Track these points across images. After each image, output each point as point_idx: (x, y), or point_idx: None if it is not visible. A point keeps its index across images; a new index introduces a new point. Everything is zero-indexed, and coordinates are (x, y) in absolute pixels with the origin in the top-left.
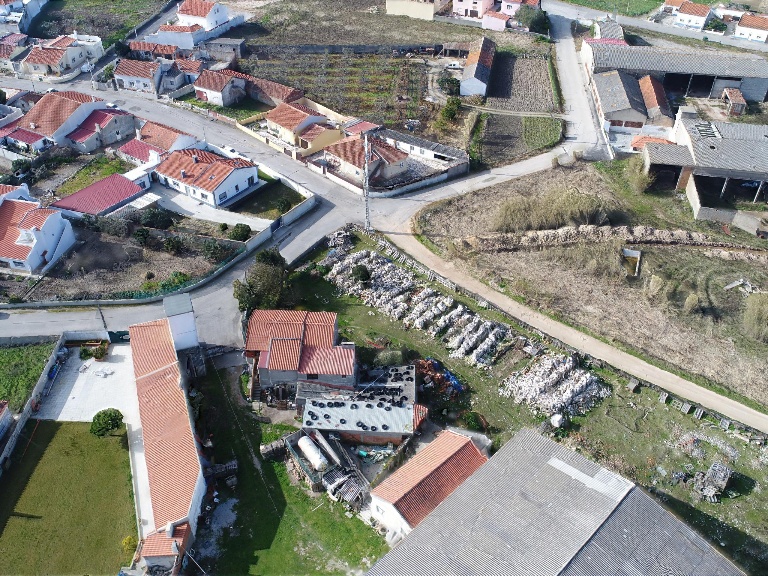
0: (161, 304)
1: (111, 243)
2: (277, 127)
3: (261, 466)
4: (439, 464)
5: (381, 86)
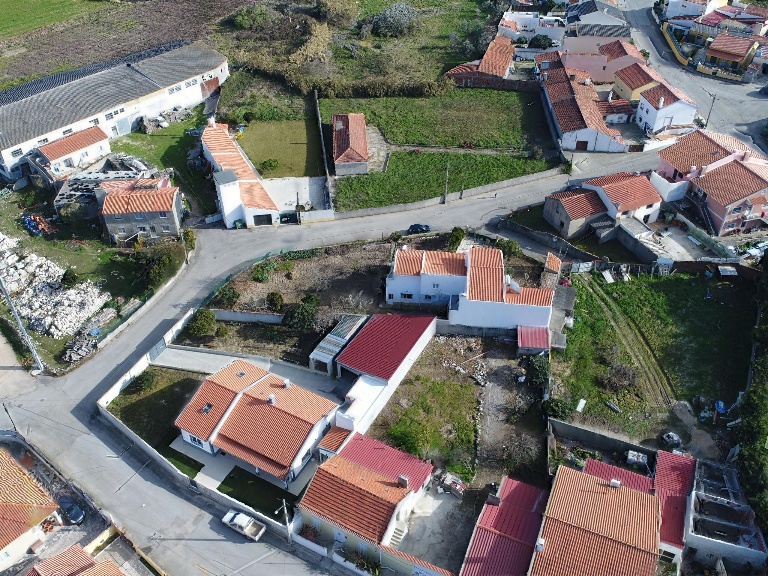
0: None
1: None
2: None
3: (175, 171)
4: (64, 139)
5: None
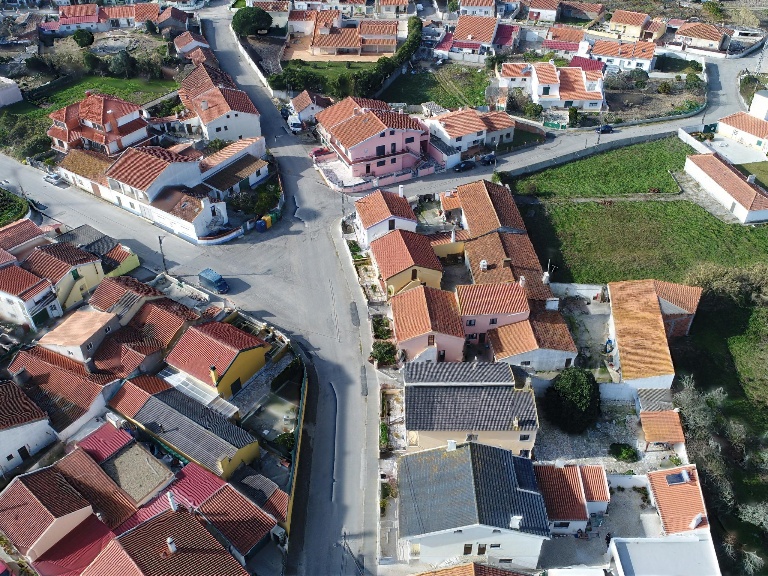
0: (698, 116)
1: (618, 93)
2: (616, 28)
3: None
4: None
5: (643, 1)
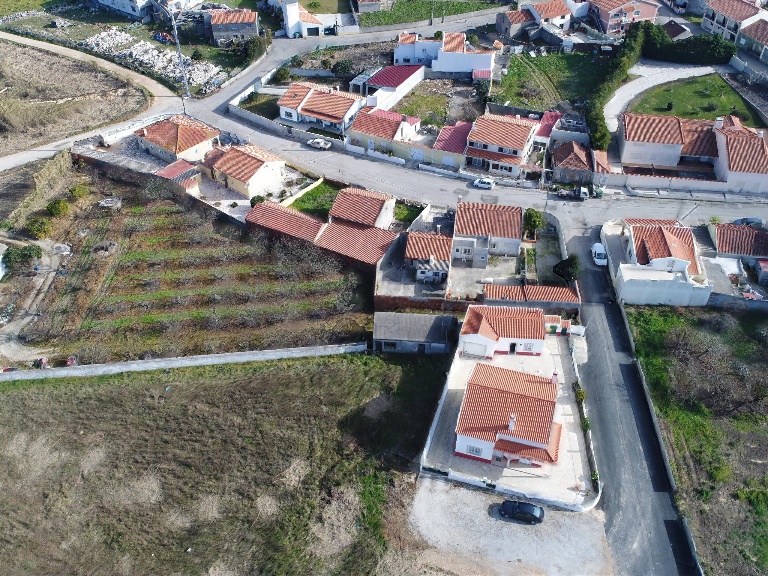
0: None
1: None
2: None
3: None
4: None
5: (131, 264)
